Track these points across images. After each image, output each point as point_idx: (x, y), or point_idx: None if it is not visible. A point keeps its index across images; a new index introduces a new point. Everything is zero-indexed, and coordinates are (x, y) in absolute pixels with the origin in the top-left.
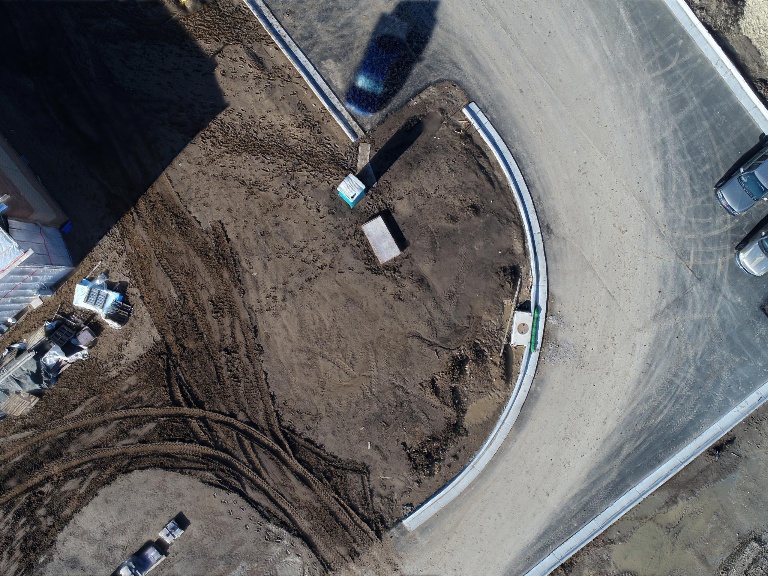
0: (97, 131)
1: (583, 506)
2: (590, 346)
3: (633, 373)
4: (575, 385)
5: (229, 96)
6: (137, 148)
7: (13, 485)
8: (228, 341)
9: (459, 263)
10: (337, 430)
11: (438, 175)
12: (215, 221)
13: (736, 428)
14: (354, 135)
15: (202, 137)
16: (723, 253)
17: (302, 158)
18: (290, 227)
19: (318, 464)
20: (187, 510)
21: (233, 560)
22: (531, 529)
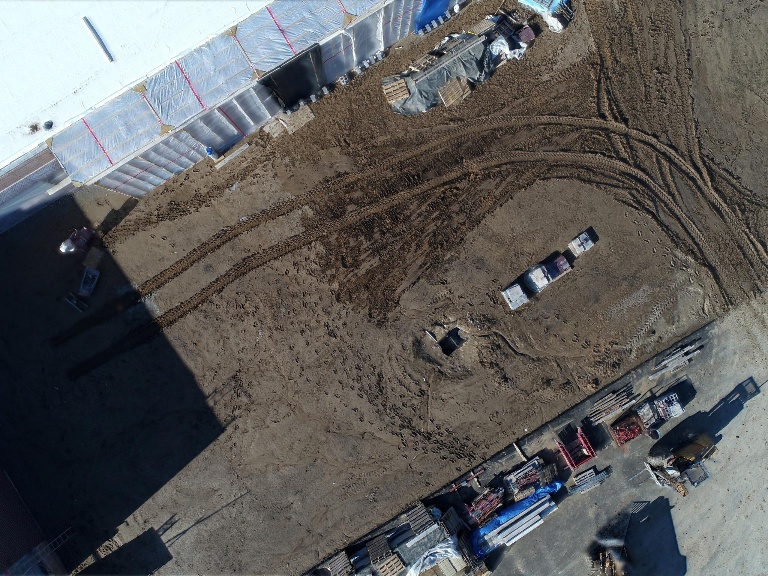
0: None
1: None
2: None
3: None
4: None
5: None
6: None
7: (431, 177)
8: (660, 61)
9: None
10: (755, 165)
11: None
12: None
13: None
14: None
15: None
16: None
17: None
18: None
19: (733, 196)
20: (597, 226)
21: (636, 282)
22: None
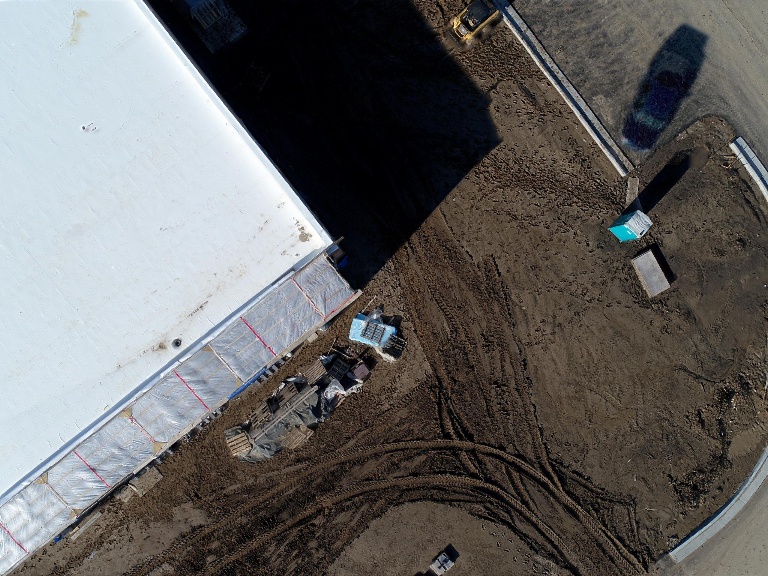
0: (373, 166)
1: None
2: None
3: None
4: None
5: (503, 132)
6: (412, 183)
7: (286, 518)
8: (498, 374)
9: (725, 297)
10: (604, 462)
11: (706, 209)
12: (487, 255)
13: None
14: (625, 170)
15: (476, 172)
16: None
17: (573, 193)
18: (560, 261)
19: (586, 496)
20: (456, 542)
21: None
22: None
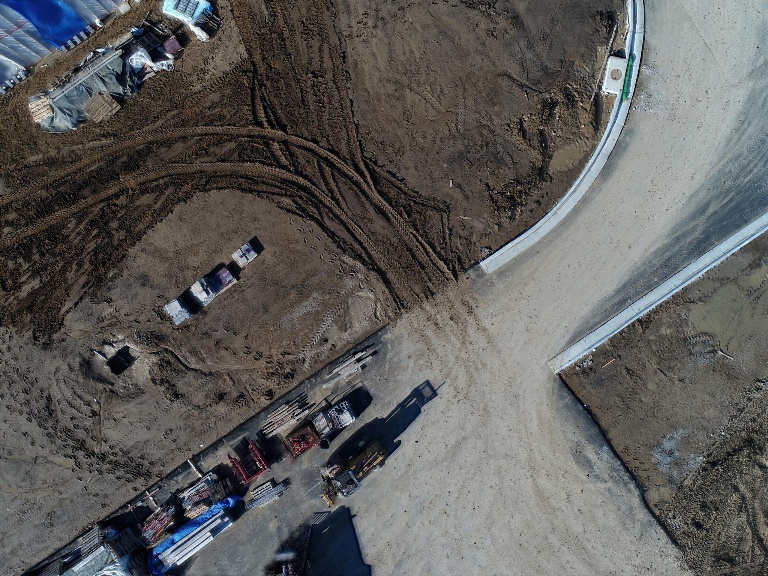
0: None
1: (665, 261)
2: (683, 98)
3: (725, 129)
4: (665, 137)
5: None
6: None
7: (87, 195)
8: (316, 65)
9: (556, 3)
10: (420, 165)
11: None
12: None
13: None
14: None
15: None
16: None
17: None
18: None
19: (398, 198)
20: (262, 235)
21: (305, 290)
22: (610, 281)
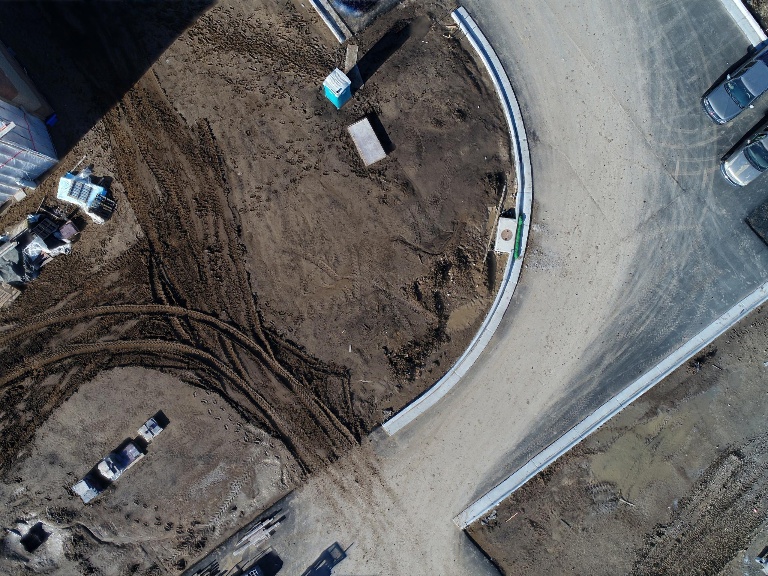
0: (85, 25)
1: (563, 414)
2: (574, 255)
3: (616, 283)
4: (558, 293)
5: None
6: (124, 43)
7: None
8: (211, 240)
9: (444, 168)
10: (319, 332)
11: (425, 79)
12: (201, 119)
13: (718, 340)
14: (342, 36)
15: (190, 34)
16: (709, 164)
17: (289, 58)
18: (276, 127)
19: (299, 366)
20: (167, 409)
21: (211, 460)
22: (510, 436)
